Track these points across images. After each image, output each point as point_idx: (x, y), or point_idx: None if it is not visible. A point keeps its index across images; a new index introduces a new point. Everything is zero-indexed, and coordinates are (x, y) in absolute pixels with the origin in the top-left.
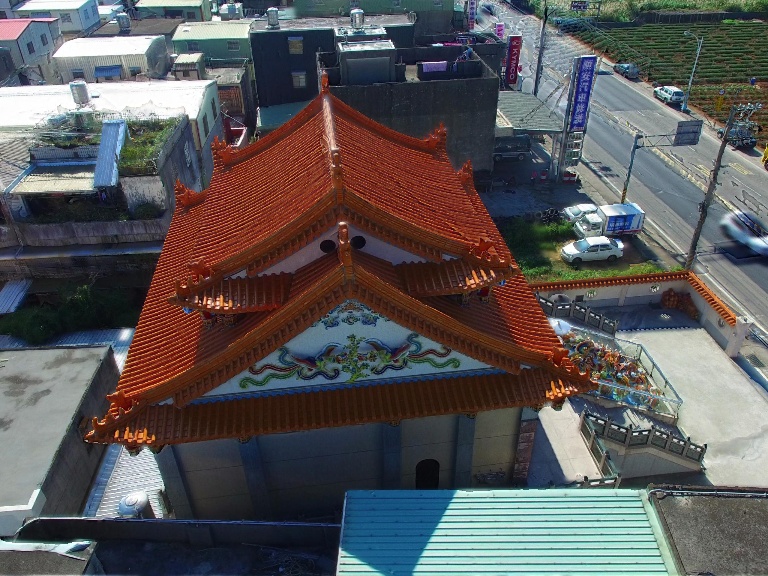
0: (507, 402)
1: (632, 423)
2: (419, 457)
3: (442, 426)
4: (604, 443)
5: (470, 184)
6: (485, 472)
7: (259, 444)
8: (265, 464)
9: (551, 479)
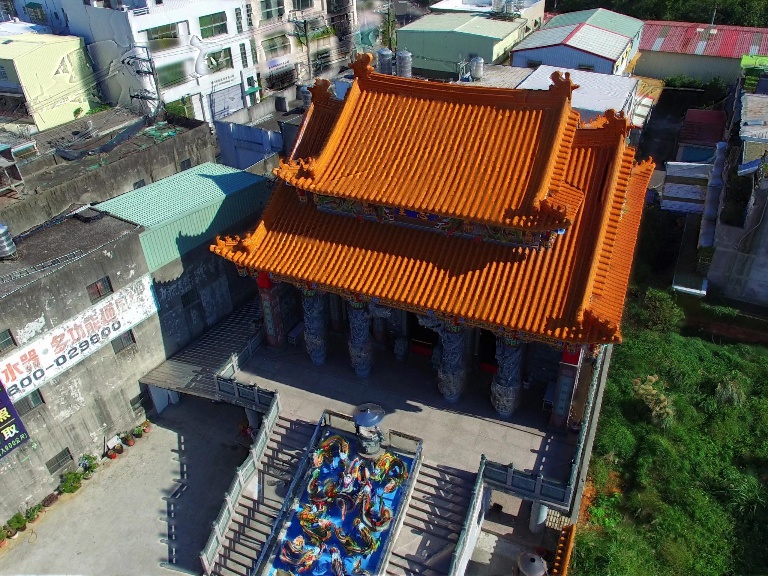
0: (252, 228)
1: (271, 497)
2: None
3: None
4: None
5: (580, 333)
6: None
7: None
8: None
9: (263, 367)
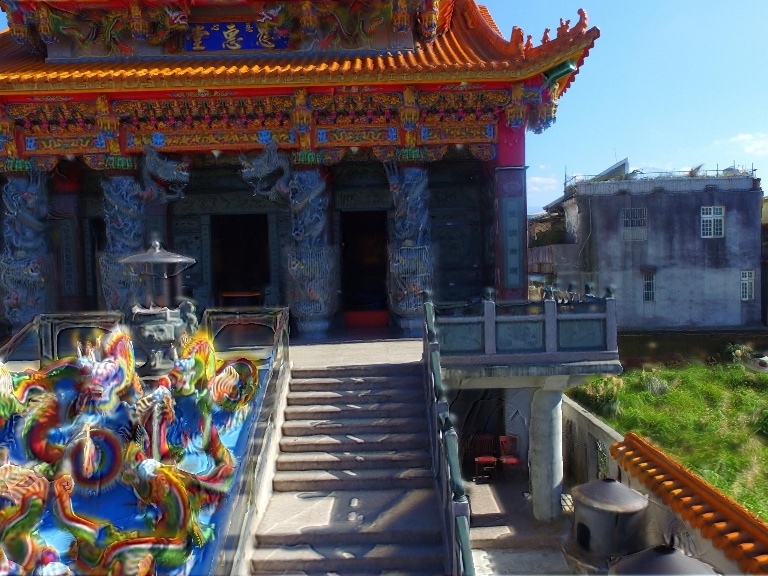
0: None
1: None
2: None
3: None
4: None
5: None
6: None
7: None
8: None
9: None
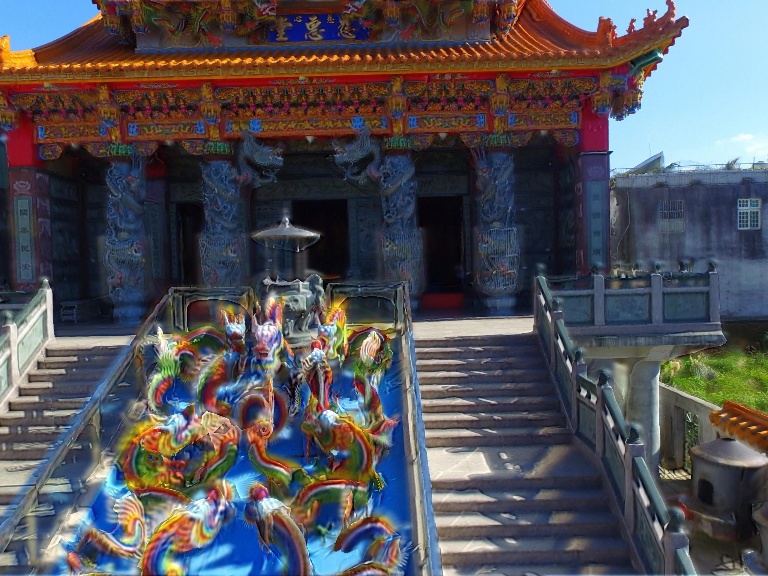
0: None
1: (18, 482)
2: None
3: None
4: None
5: None
6: None
7: None
8: None
9: None
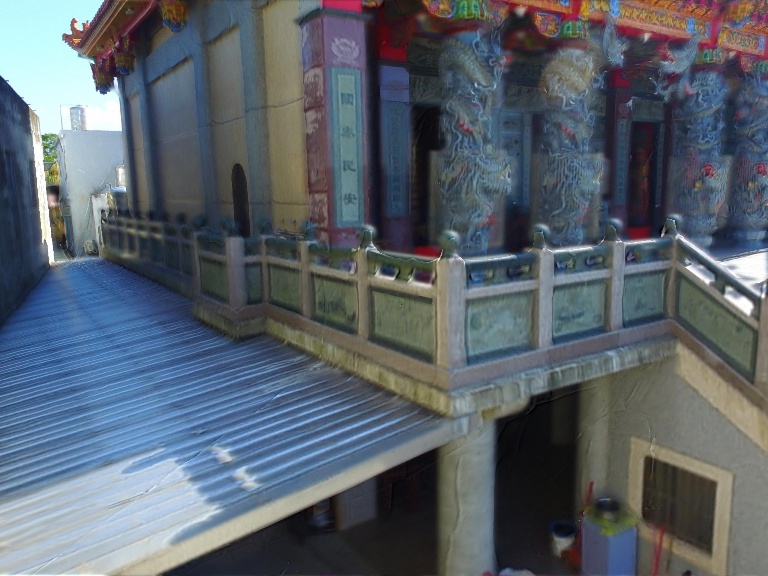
0: None
1: None
2: (232, 157)
3: (241, 67)
4: (759, 429)
5: None
6: (291, 228)
7: (152, 104)
8: (155, 144)
9: None
